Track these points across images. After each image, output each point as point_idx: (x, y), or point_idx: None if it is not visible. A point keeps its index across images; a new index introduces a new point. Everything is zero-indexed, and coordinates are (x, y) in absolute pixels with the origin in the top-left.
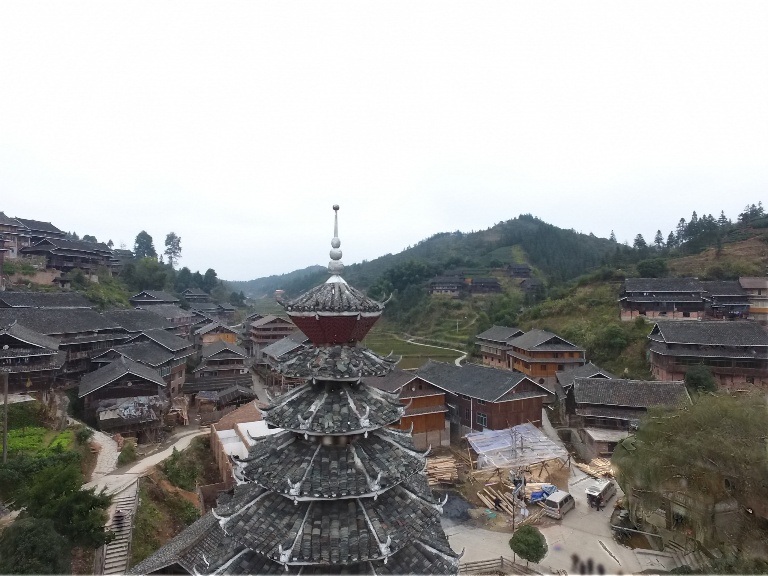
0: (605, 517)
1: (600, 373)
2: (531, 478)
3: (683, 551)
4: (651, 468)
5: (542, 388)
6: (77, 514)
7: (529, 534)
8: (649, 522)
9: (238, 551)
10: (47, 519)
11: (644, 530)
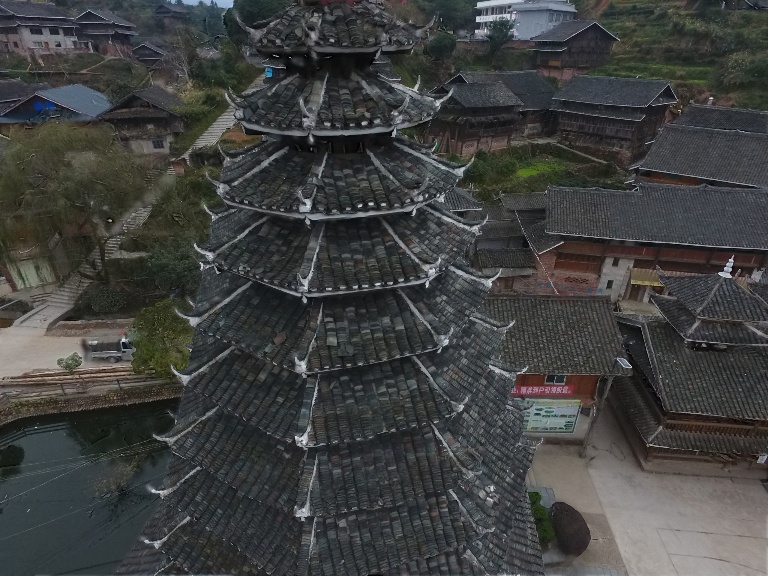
0: None
1: None
2: None
3: (51, 295)
4: (62, 211)
5: None
6: None
7: None
8: None
9: (418, 299)
10: None
11: None
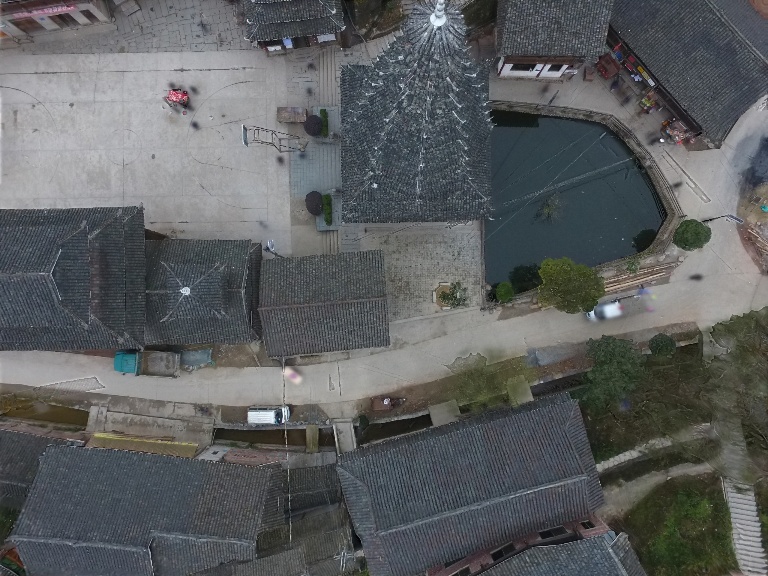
0: None
1: None
2: None
3: None
4: (717, 326)
5: None
6: None
7: (695, 234)
8: None
9: None
10: None
11: None
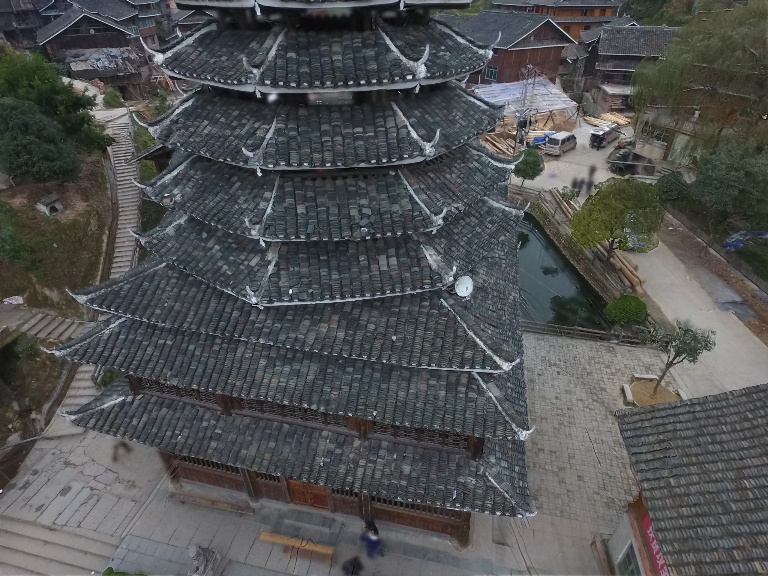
0: (604, 154)
1: (634, 23)
2: (536, 126)
3: None
4: (680, 66)
5: (565, 35)
6: (62, 105)
7: (529, 155)
8: (646, 157)
9: None
10: (28, 101)
11: (638, 166)
